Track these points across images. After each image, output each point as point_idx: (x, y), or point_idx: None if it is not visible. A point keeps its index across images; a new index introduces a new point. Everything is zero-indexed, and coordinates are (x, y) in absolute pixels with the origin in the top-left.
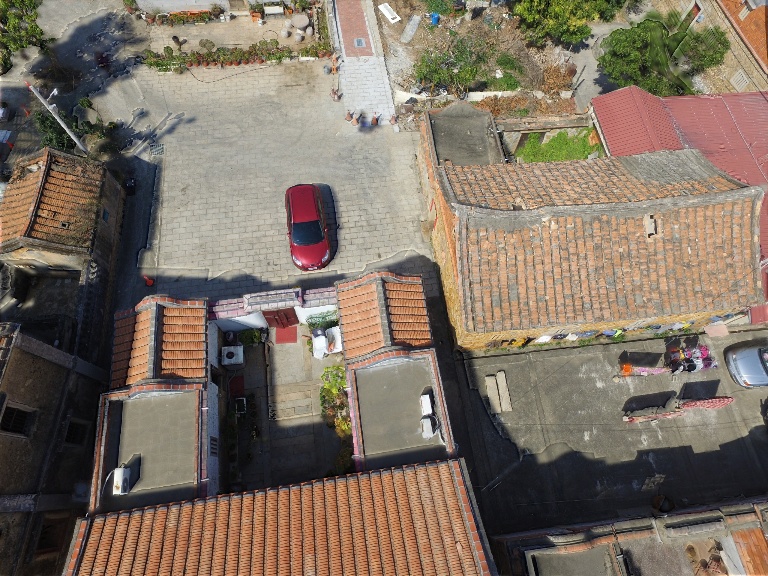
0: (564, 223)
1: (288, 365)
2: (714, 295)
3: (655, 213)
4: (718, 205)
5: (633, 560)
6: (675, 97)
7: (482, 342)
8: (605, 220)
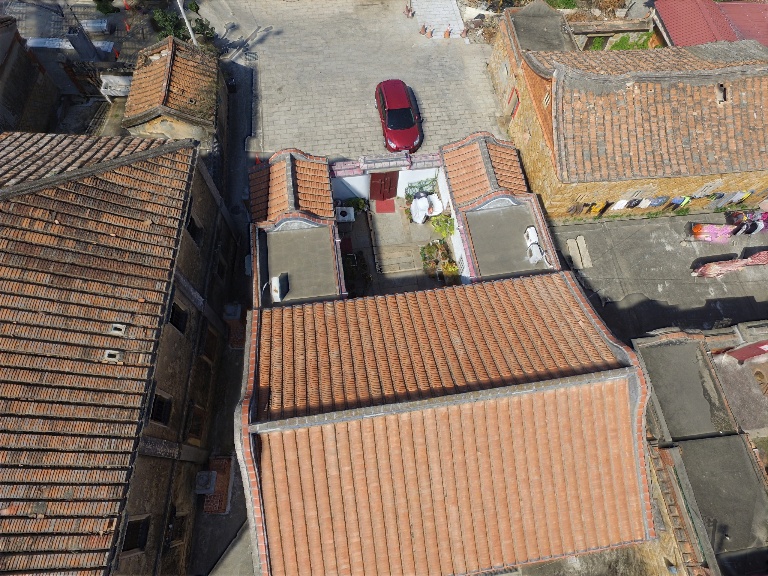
0: (645, 88)
1: (389, 230)
2: None
3: (725, 82)
4: None
5: None
6: (729, 2)
7: (565, 206)
8: (681, 87)
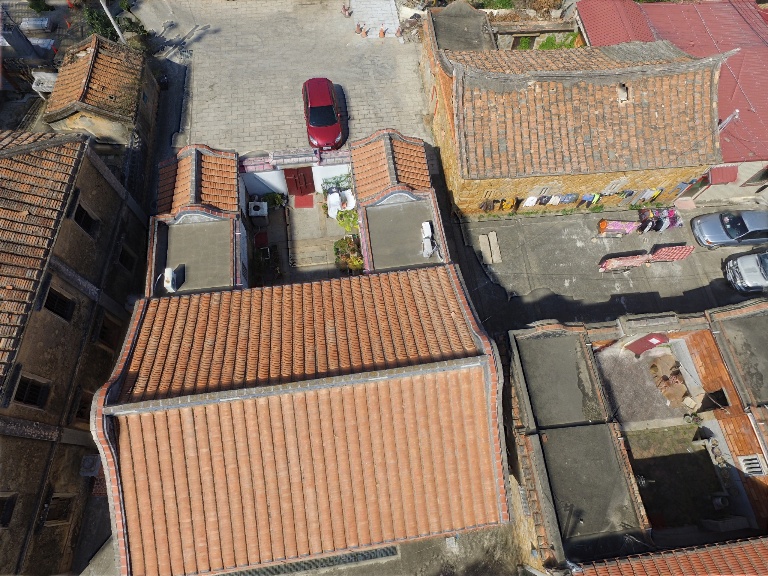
0: (547, 88)
1: (306, 225)
2: (678, 153)
3: (627, 81)
4: (682, 75)
5: (604, 375)
6: (651, 3)
7: (476, 202)
8: (583, 86)
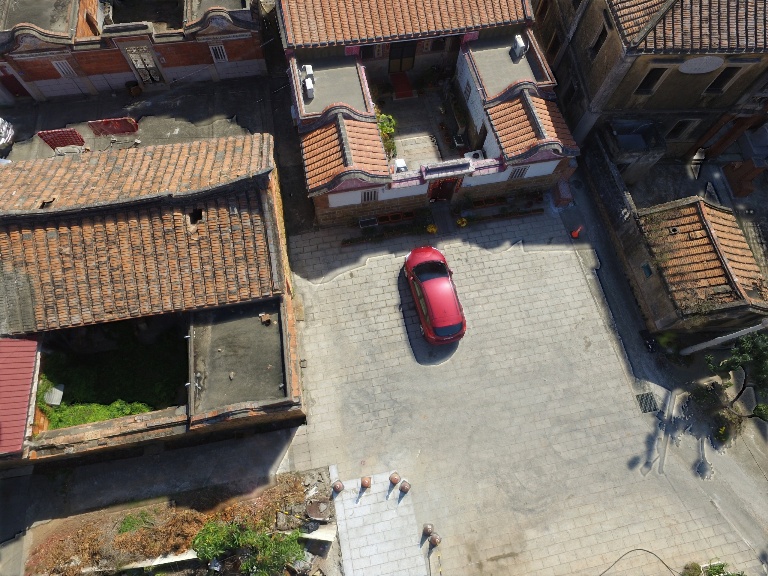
0: None
1: None
2: (11, 169)
3: None
4: None
5: None
6: None
7: None
8: None
